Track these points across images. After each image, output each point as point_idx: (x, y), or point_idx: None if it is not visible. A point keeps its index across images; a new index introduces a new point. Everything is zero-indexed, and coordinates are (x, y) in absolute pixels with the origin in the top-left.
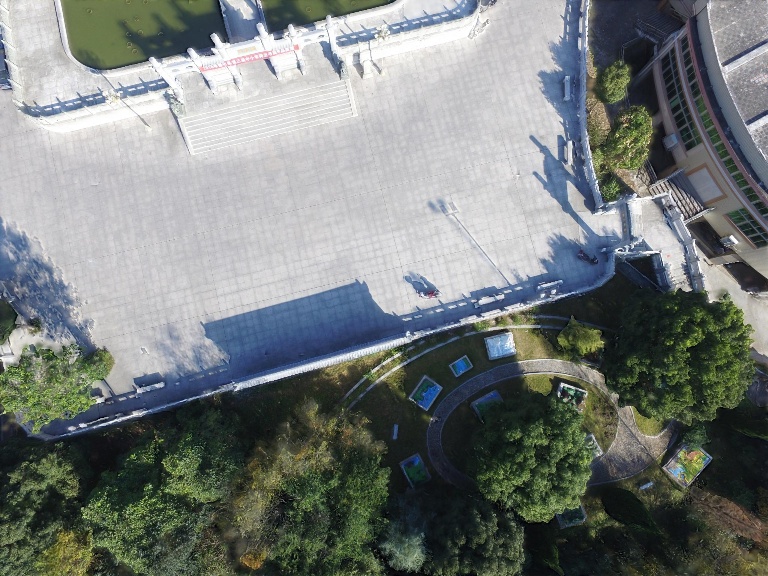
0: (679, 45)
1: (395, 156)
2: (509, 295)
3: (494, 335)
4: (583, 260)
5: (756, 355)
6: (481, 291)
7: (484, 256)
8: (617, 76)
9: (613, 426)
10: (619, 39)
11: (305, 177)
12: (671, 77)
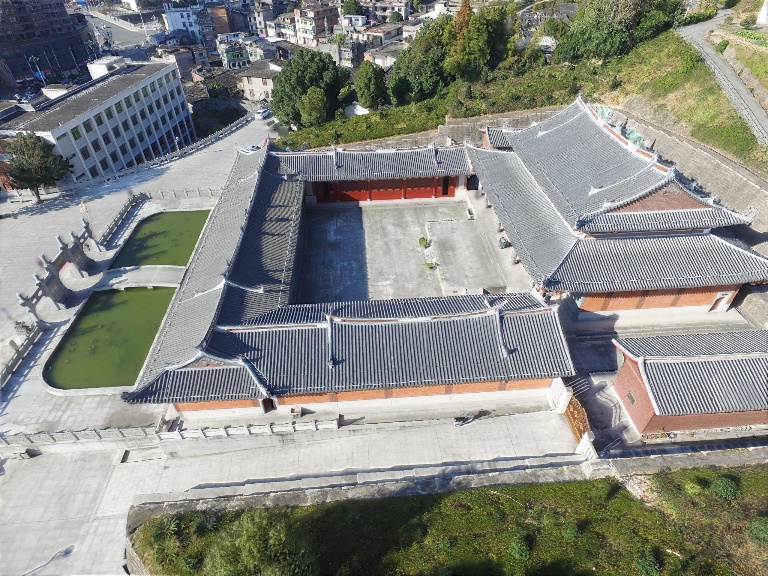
0: None
1: None
2: None
3: None
4: None
5: None
6: None
7: None
8: None
9: None
10: None
11: None
12: None
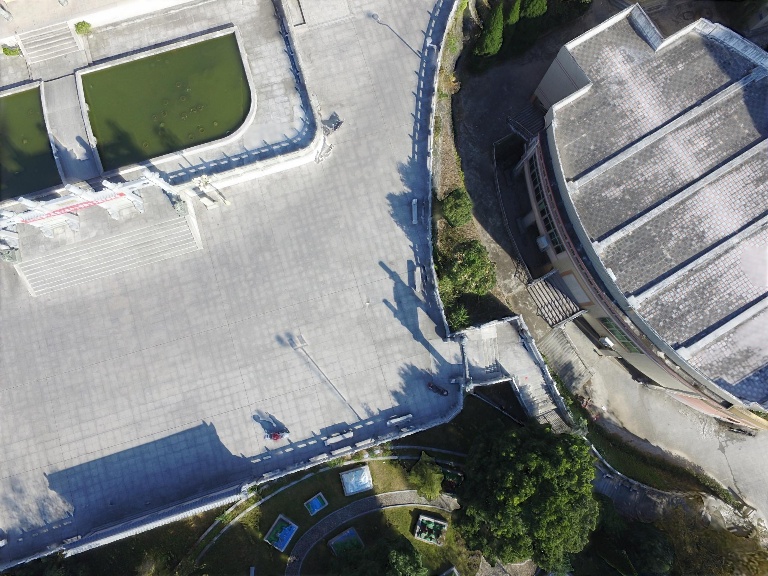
0: (538, 152)
1: (242, 289)
2: (360, 431)
3: (350, 469)
4: (433, 392)
5: (649, 447)
6: (331, 428)
7: (334, 390)
8: (455, 206)
9: (476, 557)
10: (493, 135)
11: (150, 315)
12: (536, 181)
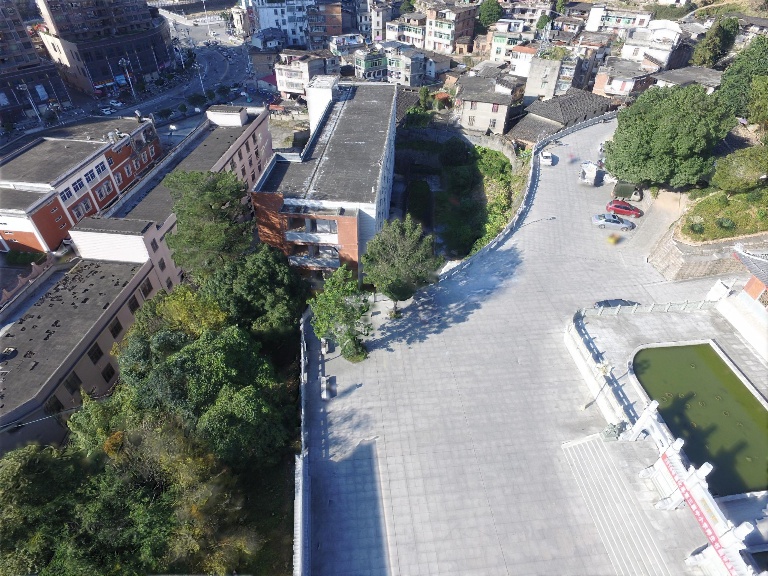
0: None
1: None
2: None
3: None
4: None
5: None
6: None
7: None
8: None
9: None
10: None
11: None
12: None
